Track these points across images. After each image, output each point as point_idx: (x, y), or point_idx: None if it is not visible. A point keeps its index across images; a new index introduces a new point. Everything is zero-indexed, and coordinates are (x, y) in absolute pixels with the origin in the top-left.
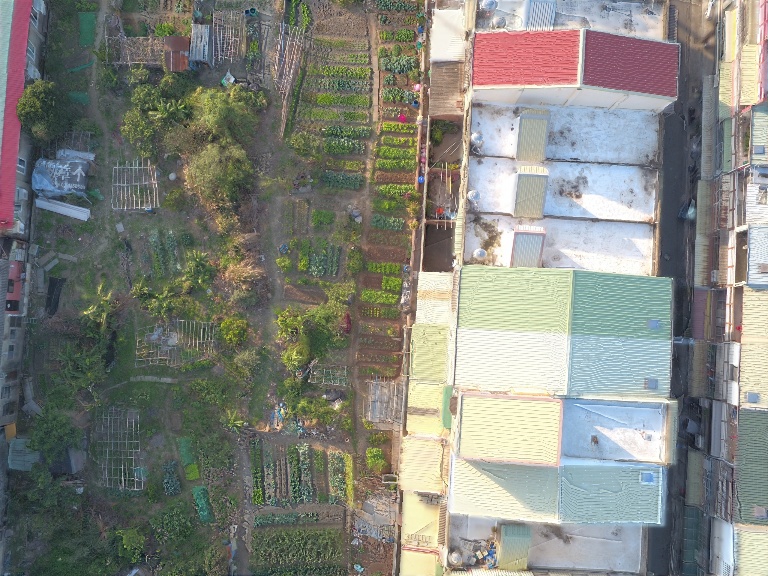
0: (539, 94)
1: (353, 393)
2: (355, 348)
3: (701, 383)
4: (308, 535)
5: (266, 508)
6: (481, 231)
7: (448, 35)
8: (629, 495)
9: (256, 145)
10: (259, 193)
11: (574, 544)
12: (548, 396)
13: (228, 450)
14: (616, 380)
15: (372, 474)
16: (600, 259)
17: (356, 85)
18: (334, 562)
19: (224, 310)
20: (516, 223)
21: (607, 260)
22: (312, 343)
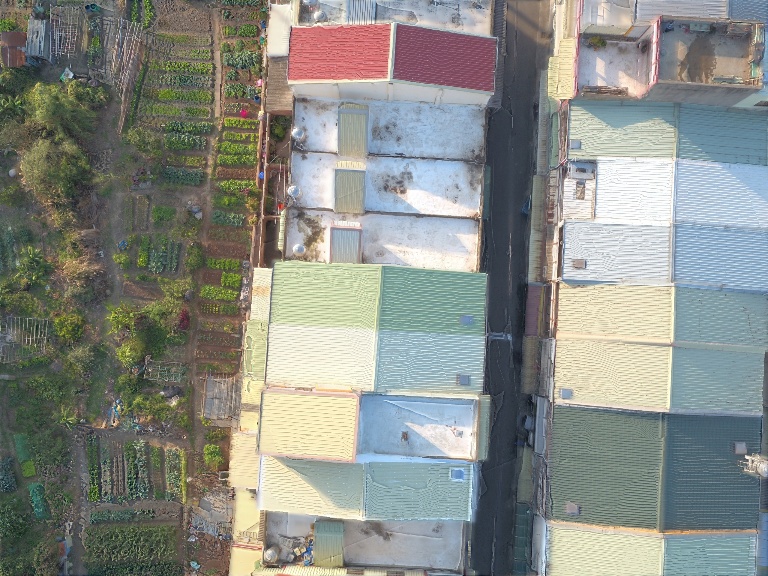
0: (356, 89)
1: (191, 390)
2: (194, 345)
3: (533, 379)
4: (142, 532)
5: (103, 505)
6: (304, 227)
7: (280, 30)
8: (437, 492)
9: (96, 141)
10: (99, 189)
11: (394, 541)
12: (350, 392)
13: (60, 447)
14: (426, 376)
15: (210, 471)
16: (424, 255)
17: (198, 81)
18: (170, 559)
19: (62, 307)
20: (340, 219)
21: (431, 256)
22: (150, 340)
